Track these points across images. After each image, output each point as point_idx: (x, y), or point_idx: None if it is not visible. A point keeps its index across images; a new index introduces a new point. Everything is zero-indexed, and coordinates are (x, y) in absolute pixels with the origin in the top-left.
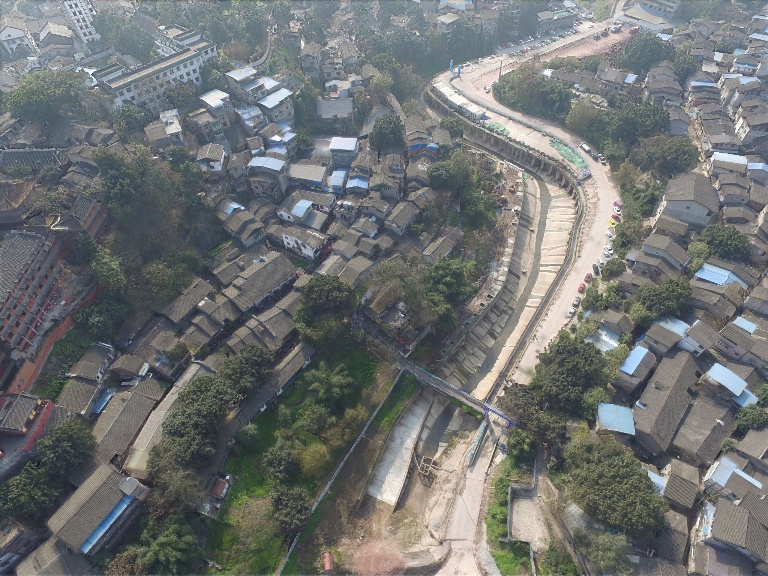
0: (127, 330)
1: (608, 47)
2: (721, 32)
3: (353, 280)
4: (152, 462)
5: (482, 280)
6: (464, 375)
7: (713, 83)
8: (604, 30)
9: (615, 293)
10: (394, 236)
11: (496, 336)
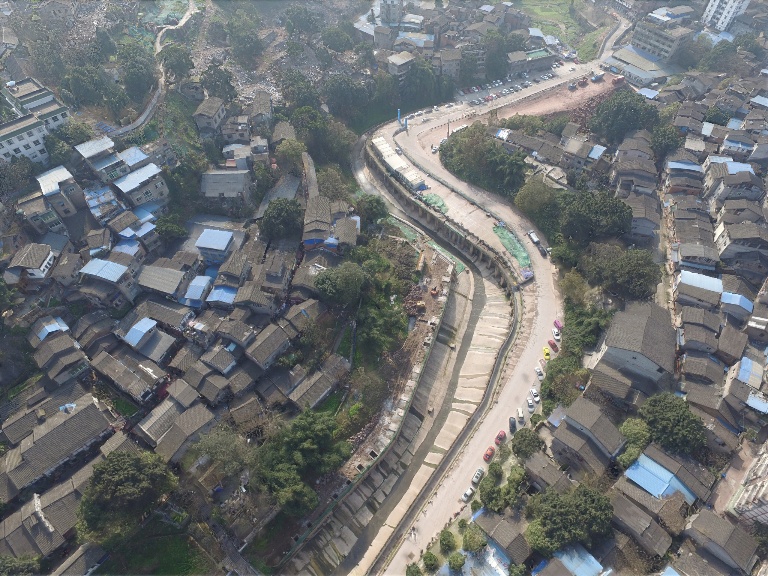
0: None
1: (583, 101)
2: (718, 91)
3: (177, 446)
4: None
5: (367, 429)
6: (322, 569)
7: (696, 166)
8: (582, 79)
9: (517, 488)
10: (255, 371)
11: (376, 508)
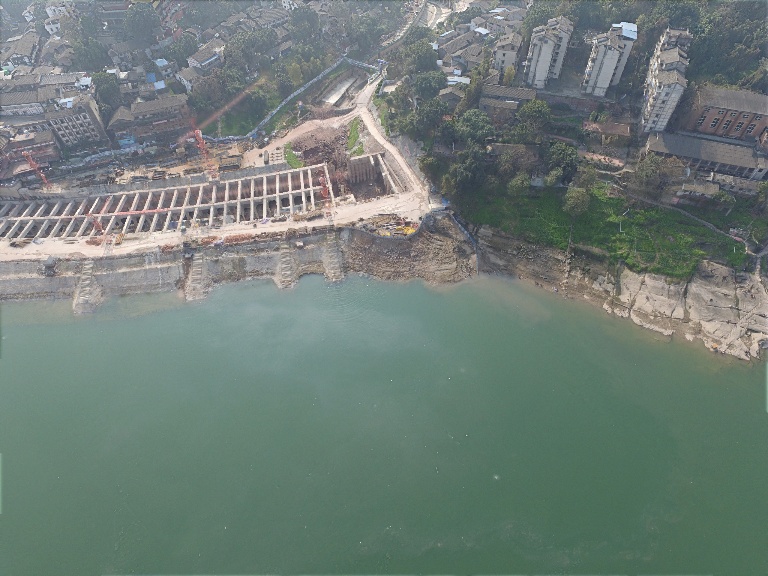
0: (207, 25)
1: None
2: None
3: None
4: (225, 51)
5: (390, 35)
6: None
7: None
8: None
9: (450, 22)
10: None
11: None
